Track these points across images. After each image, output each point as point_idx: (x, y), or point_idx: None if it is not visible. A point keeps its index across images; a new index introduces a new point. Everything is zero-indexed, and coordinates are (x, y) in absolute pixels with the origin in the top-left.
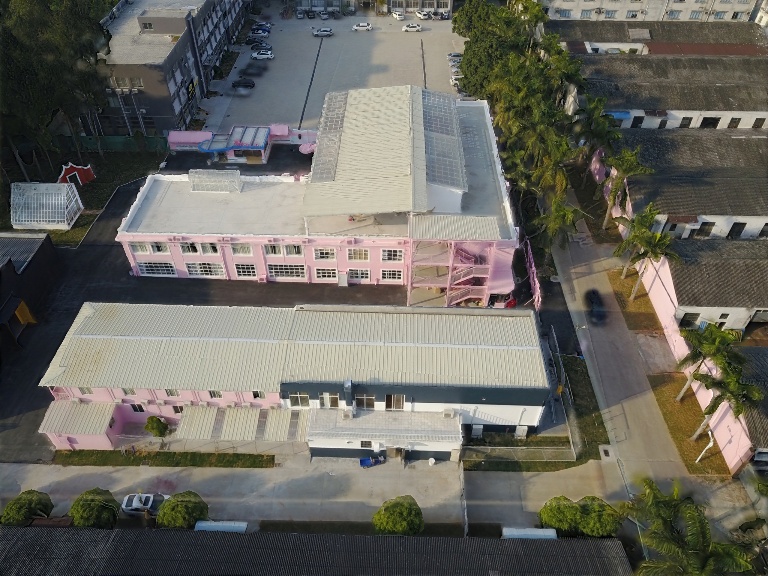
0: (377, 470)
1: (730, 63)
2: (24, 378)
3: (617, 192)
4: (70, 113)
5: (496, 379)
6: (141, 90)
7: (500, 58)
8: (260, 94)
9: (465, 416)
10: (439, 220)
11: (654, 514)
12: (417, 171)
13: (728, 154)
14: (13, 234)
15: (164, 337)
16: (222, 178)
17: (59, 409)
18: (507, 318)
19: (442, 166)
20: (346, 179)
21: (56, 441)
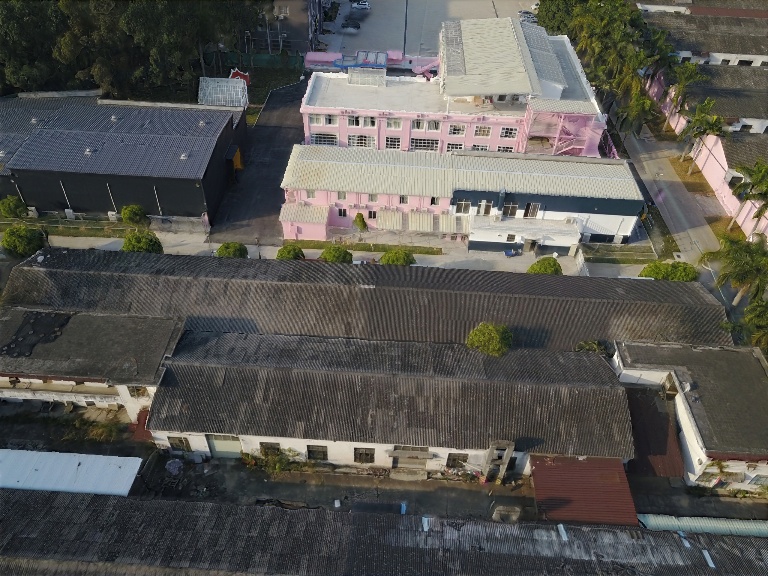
0: (517, 259)
1: (760, 22)
2: (245, 200)
3: (680, 94)
4: (249, 23)
5: (605, 196)
6: (286, 17)
7: (575, 6)
8: (366, 34)
9: (580, 225)
10: (551, 102)
11: (727, 247)
12: (530, 70)
13: (761, 82)
14: (217, 107)
15: (363, 163)
16: (374, 74)
17: (290, 208)
18: (606, 165)
19: (546, 70)
20: (475, 74)
21: (287, 231)
